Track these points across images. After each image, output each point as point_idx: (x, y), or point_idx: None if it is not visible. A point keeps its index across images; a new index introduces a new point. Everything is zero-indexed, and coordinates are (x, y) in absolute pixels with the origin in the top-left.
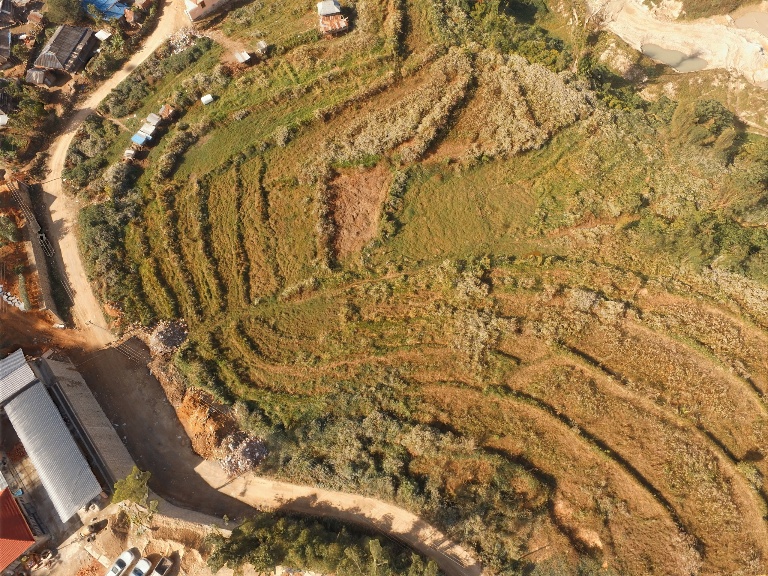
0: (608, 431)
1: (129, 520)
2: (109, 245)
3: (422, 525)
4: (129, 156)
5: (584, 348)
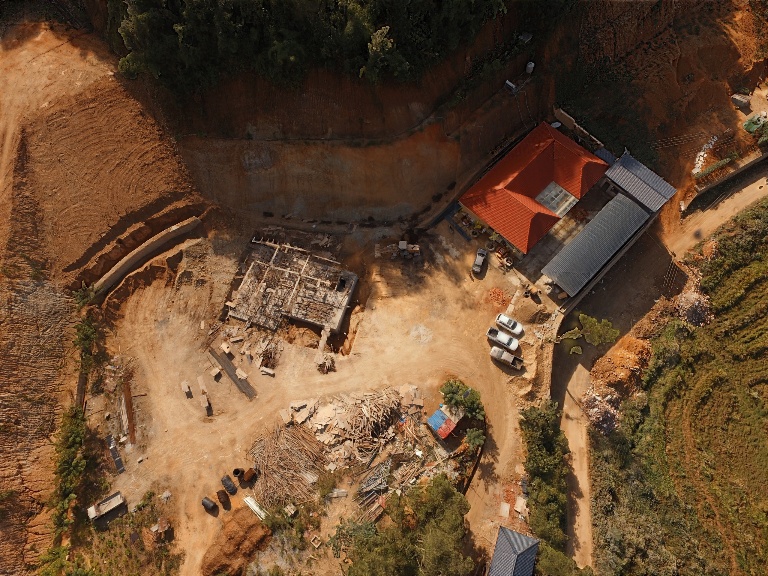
0: None
1: (545, 322)
2: None
3: None
4: None
5: None
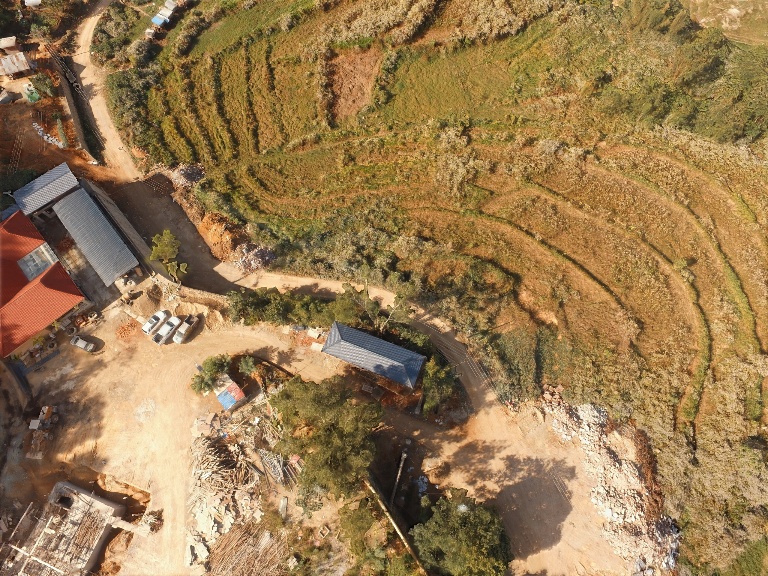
0: (566, 243)
1: (161, 291)
2: (134, 104)
3: (407, 304)
4: (149, 34)
5: (549, 185)
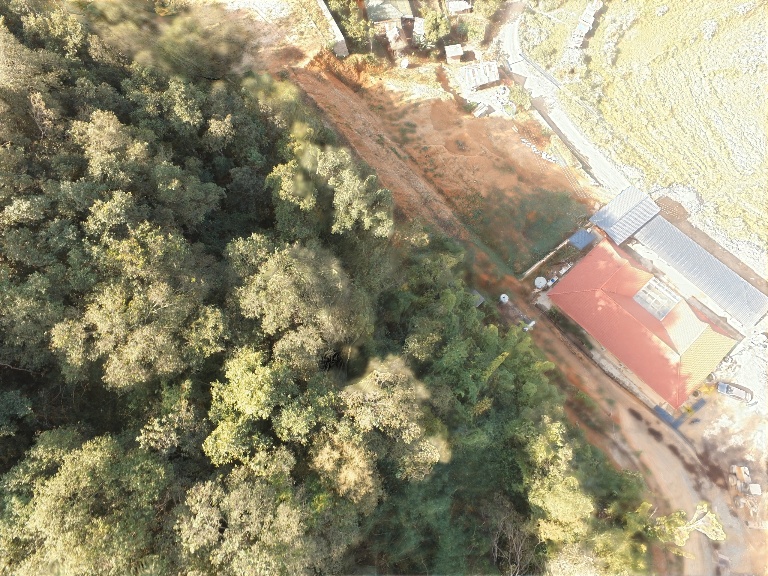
0: None
1: None
2: (599, 118)
3: None
4: (580, 43)
5: None
